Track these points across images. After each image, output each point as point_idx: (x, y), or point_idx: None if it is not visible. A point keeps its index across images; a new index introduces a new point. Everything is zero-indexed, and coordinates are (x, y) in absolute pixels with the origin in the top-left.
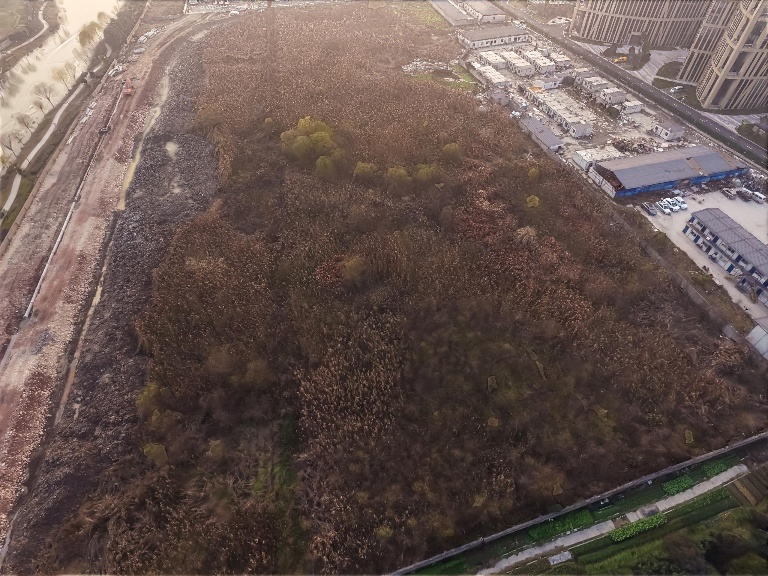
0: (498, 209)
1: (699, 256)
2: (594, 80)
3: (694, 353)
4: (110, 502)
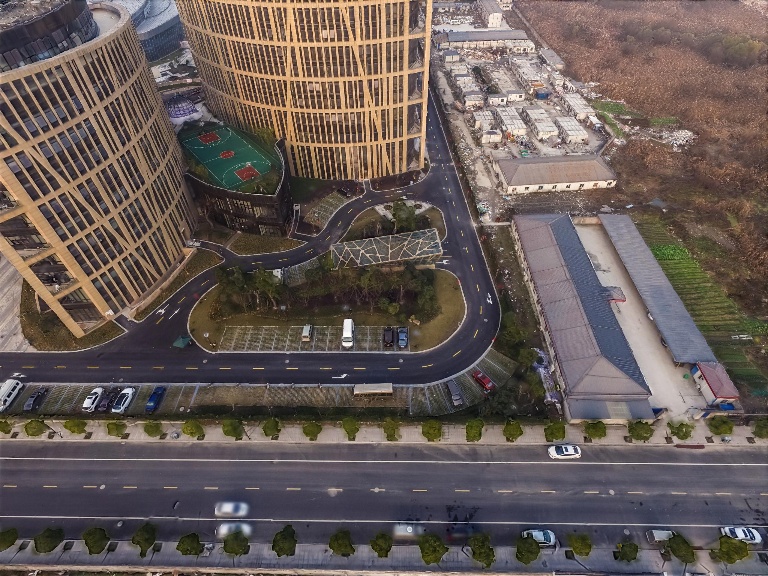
0: (598, 29)
1: (502, 22)
2: (471, 87)
3: (535, 5)
4: (721, 2)
